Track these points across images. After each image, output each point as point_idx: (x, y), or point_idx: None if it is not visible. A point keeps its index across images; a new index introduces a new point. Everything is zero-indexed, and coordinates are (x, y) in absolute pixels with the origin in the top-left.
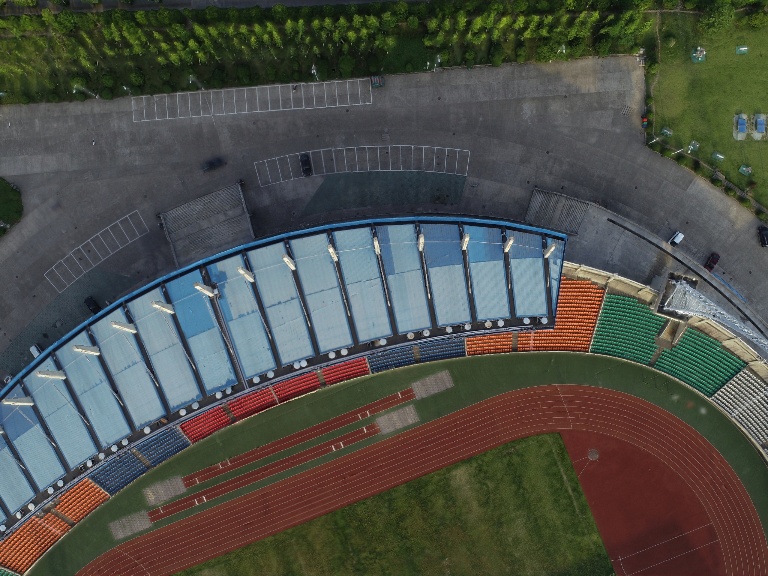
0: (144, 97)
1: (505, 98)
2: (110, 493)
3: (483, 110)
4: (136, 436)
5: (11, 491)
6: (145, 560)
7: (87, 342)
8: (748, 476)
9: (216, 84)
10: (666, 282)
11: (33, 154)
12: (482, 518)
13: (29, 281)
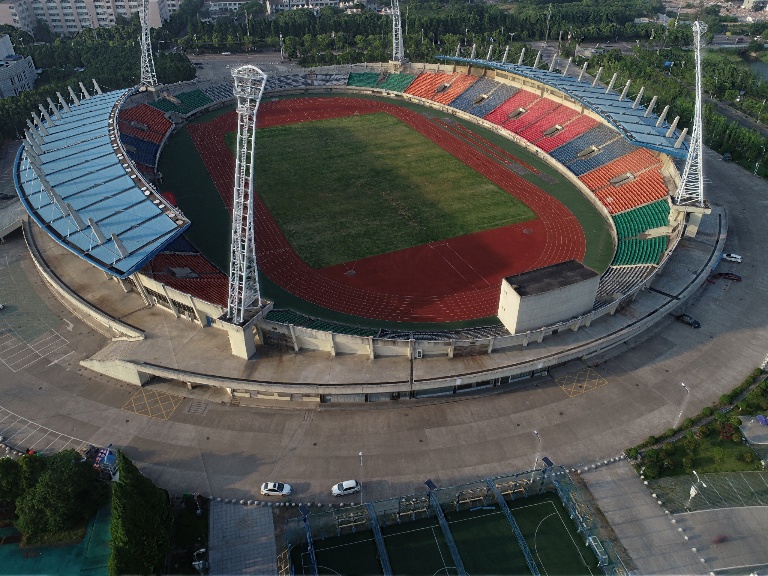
0: None
1: (765, 195)
2: (449, 105)
3: None
4: None
5: None
6: None
7: None
8: None
9: (679, 124)
10: None
11: None
12: None
13: None
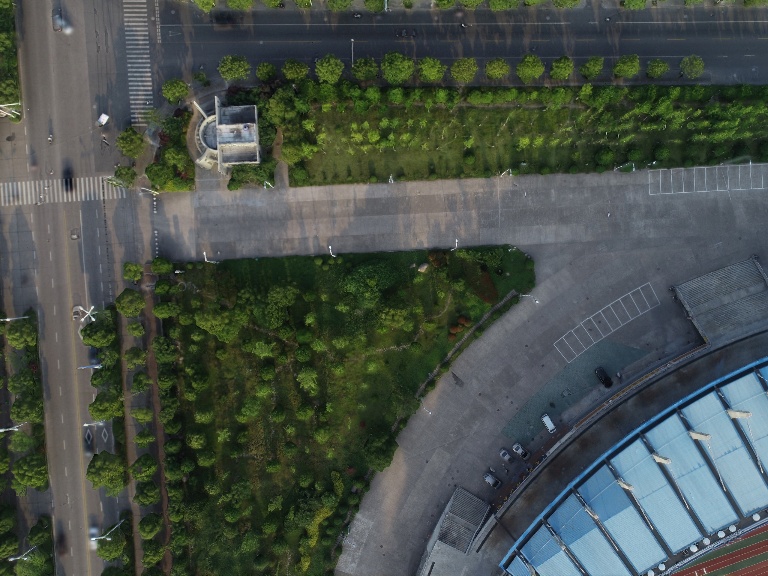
0: (661, 170)
1: None
2: None
3: None
4: (744, 523)
5: (604, 573)
6: None
7: (680, 425)
8: None
9: (739, 160)
10: None
11: (548, 224)
12: None
13: (538, 350)
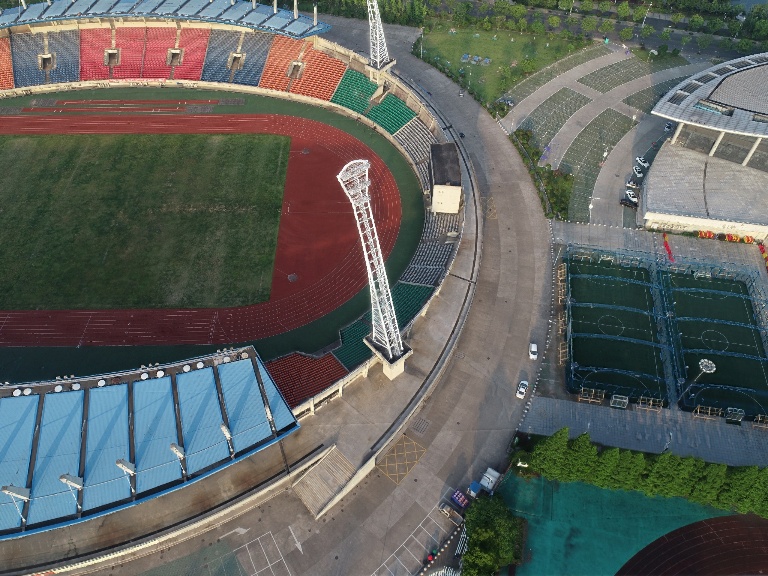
0: None
1: None
2: (16, 86)
3: (333, 27)
4: None
5: None
6: None
7: None
8: (404, 186)
9: None
10: None
11: None
12: (214, 160)
13: None
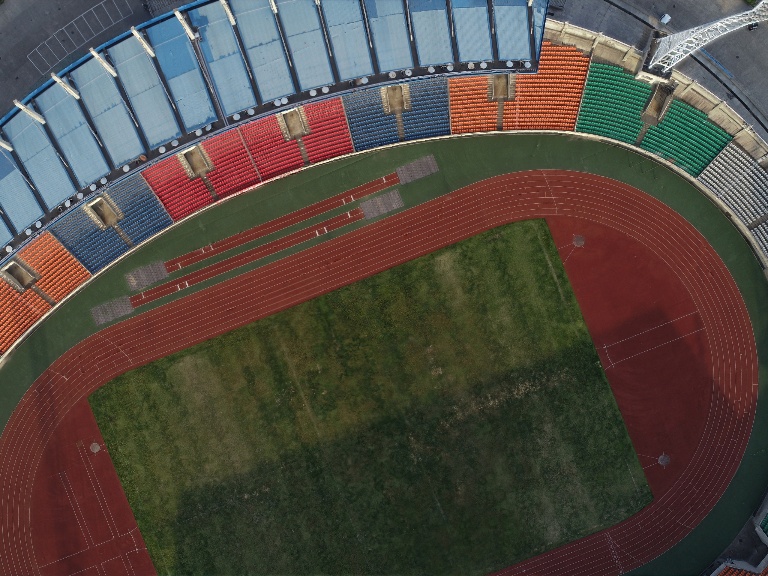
0: None
1: None
2: (91, 272)
3: None
4: (115, 175)
5: None
6: (127, 346)
7: None
8: (734, 263)
9: None
10: (651, 39)
11: None
12: (466, 305)
13: (12, 63)
